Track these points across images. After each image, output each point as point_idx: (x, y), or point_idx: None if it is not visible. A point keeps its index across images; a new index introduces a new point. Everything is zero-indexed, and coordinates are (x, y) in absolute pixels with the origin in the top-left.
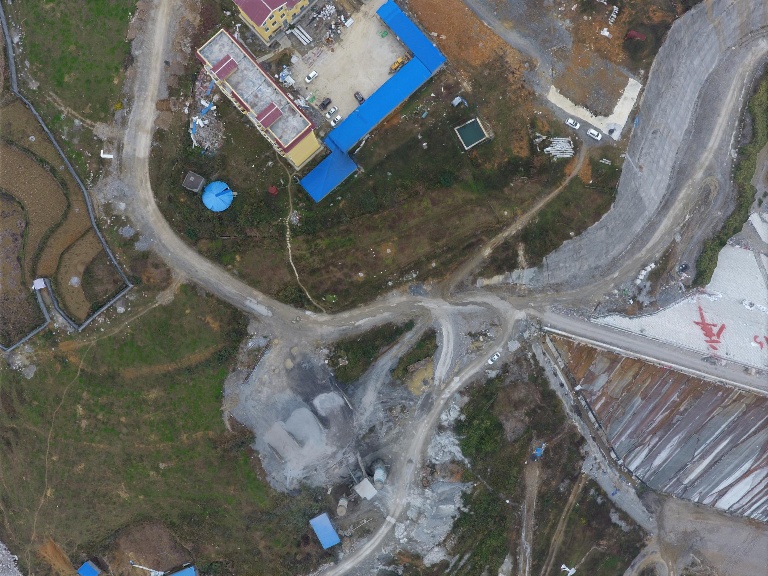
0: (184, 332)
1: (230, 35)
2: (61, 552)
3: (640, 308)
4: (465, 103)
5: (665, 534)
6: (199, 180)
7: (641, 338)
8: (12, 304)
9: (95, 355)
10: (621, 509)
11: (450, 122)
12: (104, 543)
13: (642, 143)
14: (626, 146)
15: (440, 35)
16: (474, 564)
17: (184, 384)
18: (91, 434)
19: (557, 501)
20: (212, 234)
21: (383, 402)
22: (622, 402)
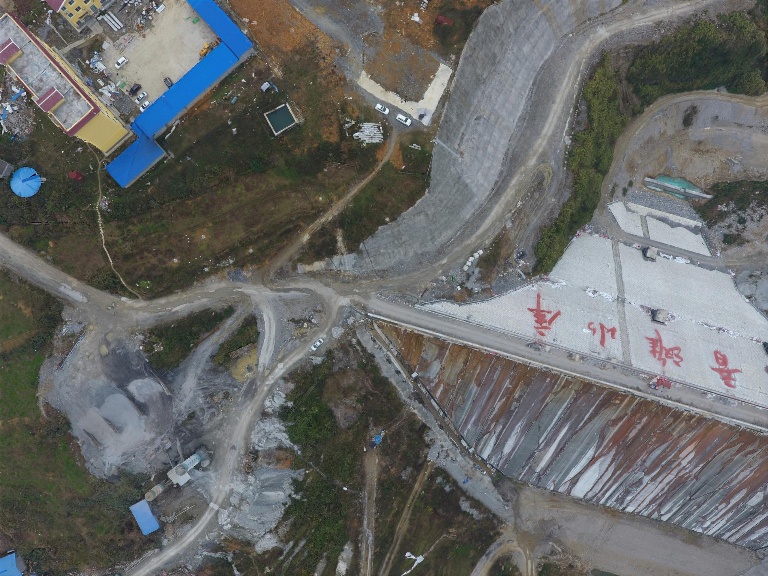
0: None
1: (15, 19)
2: None
3: (470, 295)
4: (275, 89)
5: (521, 522)
6: (4, 166)
7: (465, 324)
8: None
9: None
10: (473, 497)
11: (260, 108)
12: None
13: (462, 129)
14: (436, 131)
15: (251, 21)
16: (310, 551)
17: None
18: None
19: (401, 489)
20: (21, 220)
21: (204, 388)
22: (460, 389)
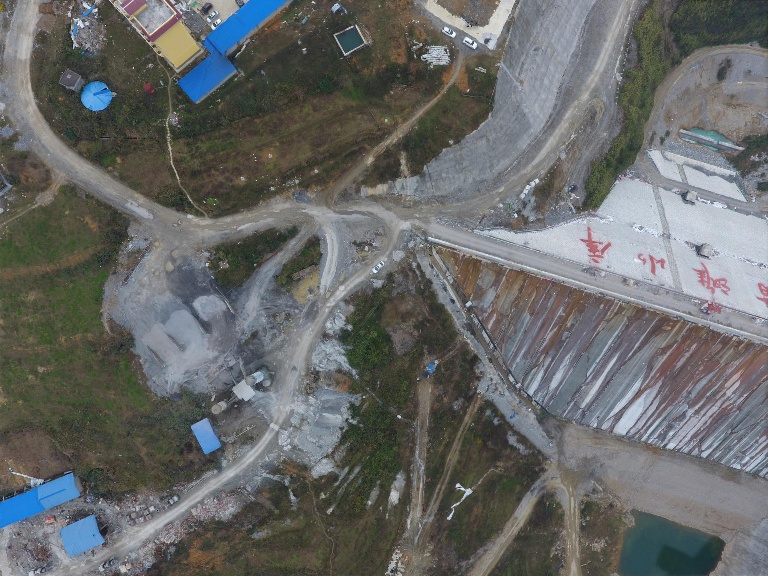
0: (63, 233)
1: None
2: None
3: (525, 223)
4: (345, 11)
5: (565, 460)
6: (76, 78)
7: (523, 249)
8: None
9: None
10: (520, 432)
11: (329, 28)
12: None
13: (522, 58)
14: (501, 55)
15: None
16: (364, 478)
17: (64, 286)
18: None
19: (452, 420)
20: (91, 134)
21: (267, 308)
22: (512, 319)
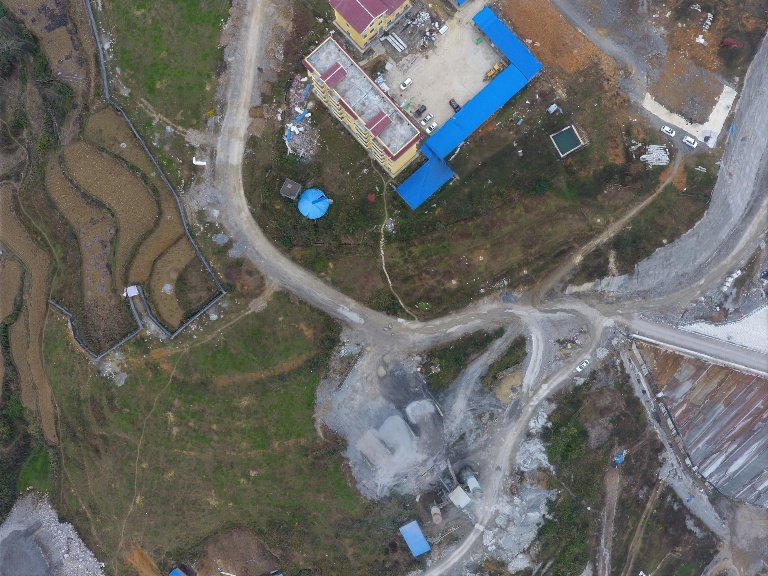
0: (277, 339)
1: (337, 43)
2: (148, 559)
3: (726, 315)
4: (560, 110)
5: (737, 540)
6: (296, 187)
7: (729, 345)
8: (102, 311)
9: (188, 362)
10: (695, 515)
11: (545, 129)
12: (193, 550)
13: (732, 150)
14: (721, 153)
15: (535, 42)
16: (556, 571)
17: (276, 391)
18: (182, 441)
19: (635, 508)
20: (307, 241)
21: (473, 409)
22: (704, 409)
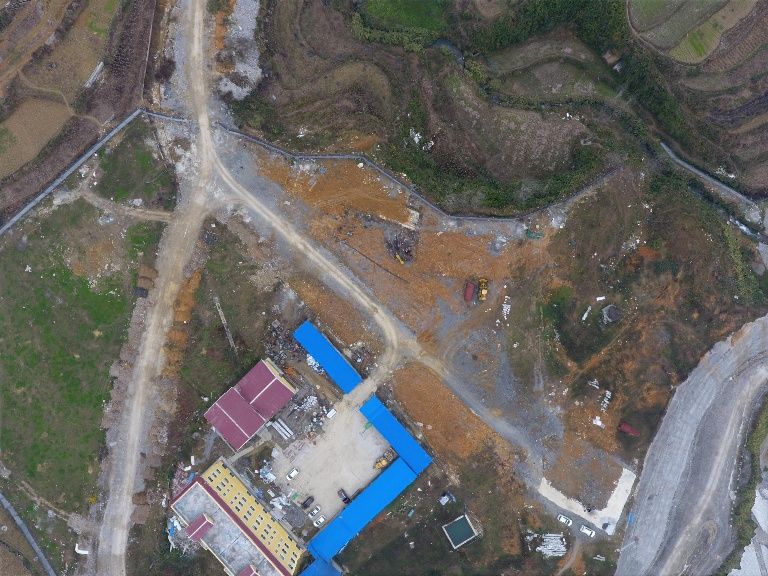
0: None
1: (205, 487)
2: None
3: None
4: (453, 498)
5: None
6: None
7: None
8: None
9: None
10: None
11: (437, 520)
12: None
13: (637, 515)
14: (621, 541)
15: (426, 426)
16: None
17: None
18: None
19: None
20: None
21: None
22: None
